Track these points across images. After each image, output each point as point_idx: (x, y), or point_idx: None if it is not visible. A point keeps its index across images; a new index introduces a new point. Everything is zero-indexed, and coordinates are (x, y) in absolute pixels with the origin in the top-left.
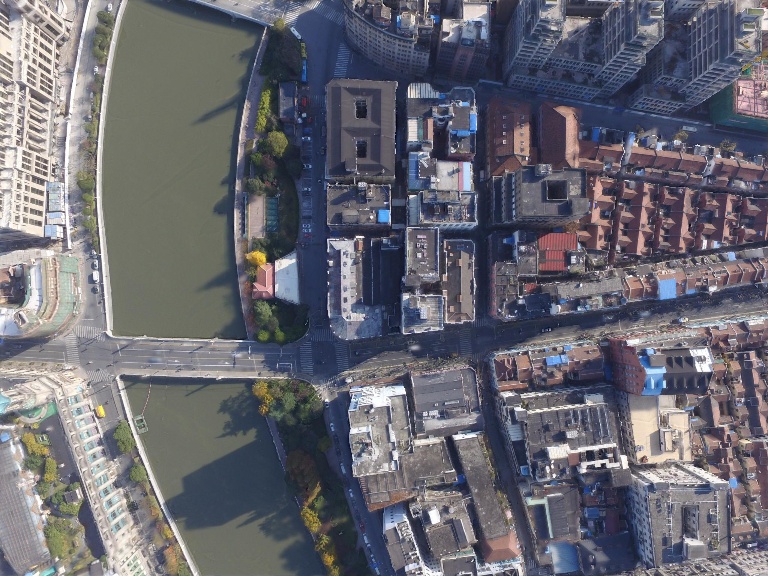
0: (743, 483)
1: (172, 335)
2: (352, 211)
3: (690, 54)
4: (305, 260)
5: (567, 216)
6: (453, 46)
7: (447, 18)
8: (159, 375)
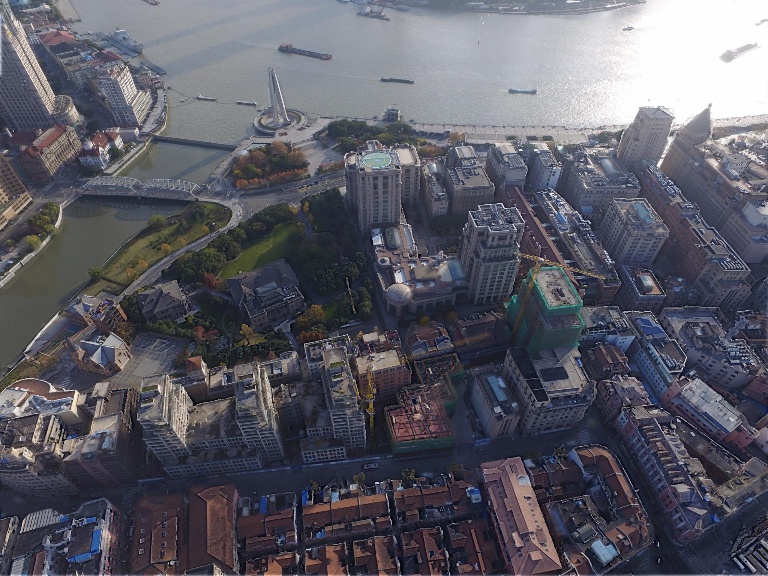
0: None
1: None
2: None
3: (326, 404)
4: None
5: None
6: None
7: None
8: None
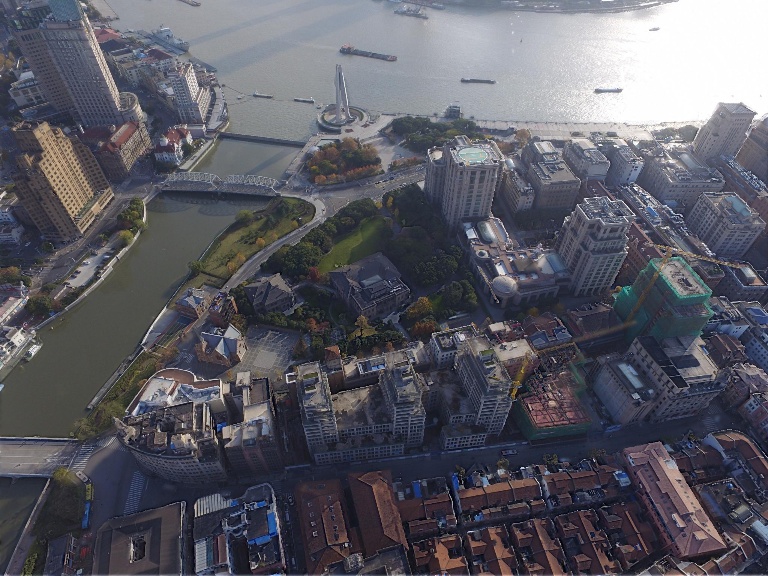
0: None
1: None
2: None
3: (466, 392)
4: None
5: None
6: (238, 448)
7: (241, 419)
8: None
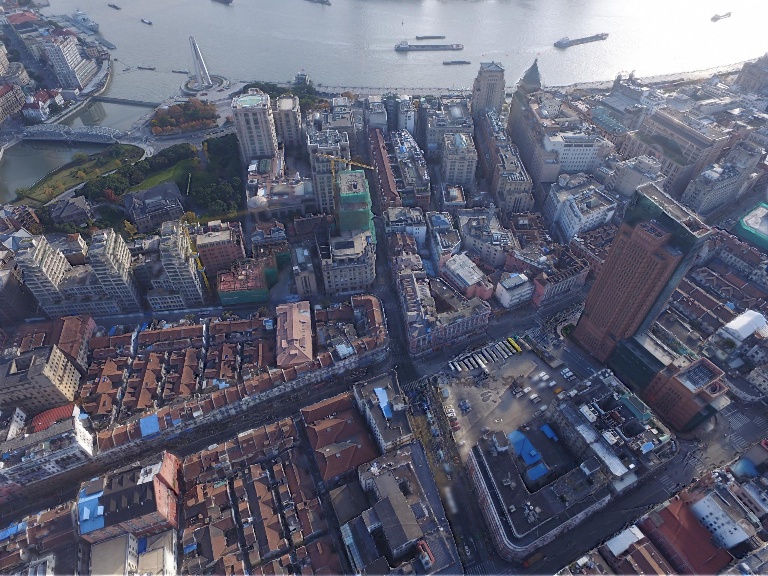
0: None
1: None
2: None
3: None
4: None
5: (29, 382)
6: None
7: None
8: None
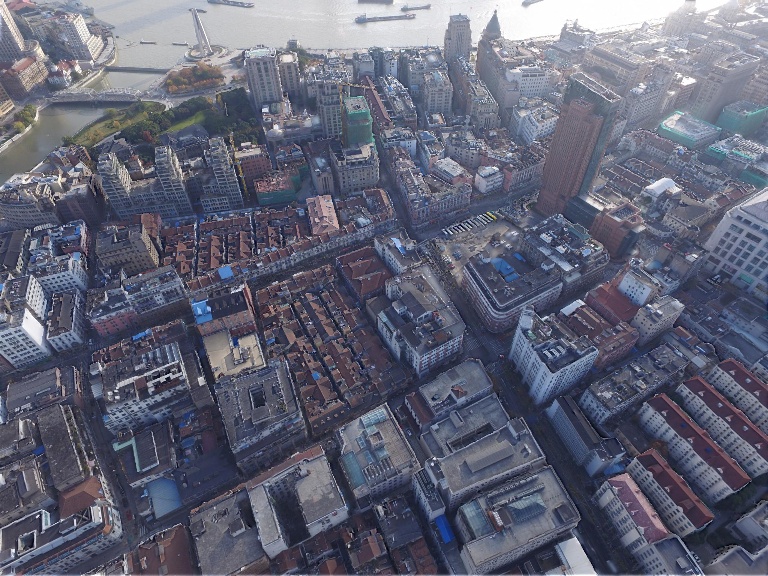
0: (332, 379)
1: None
2: None
3: None
4: None
5: (131, 247)
6: (65, 203)
7: None
8: None
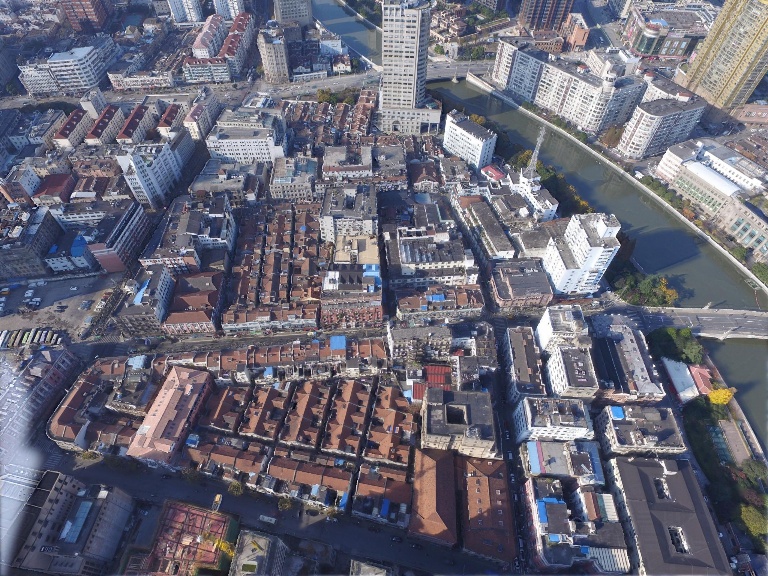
0: (292, 231)
1: (761, 347)
2: (651, 418)
3: None
4: (667, 400)
5: None
6: None
7: None
8: (759, 312)
